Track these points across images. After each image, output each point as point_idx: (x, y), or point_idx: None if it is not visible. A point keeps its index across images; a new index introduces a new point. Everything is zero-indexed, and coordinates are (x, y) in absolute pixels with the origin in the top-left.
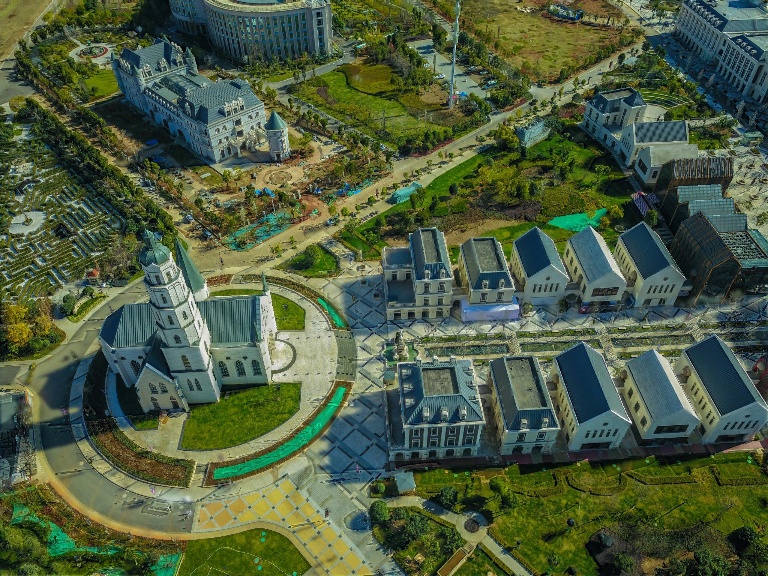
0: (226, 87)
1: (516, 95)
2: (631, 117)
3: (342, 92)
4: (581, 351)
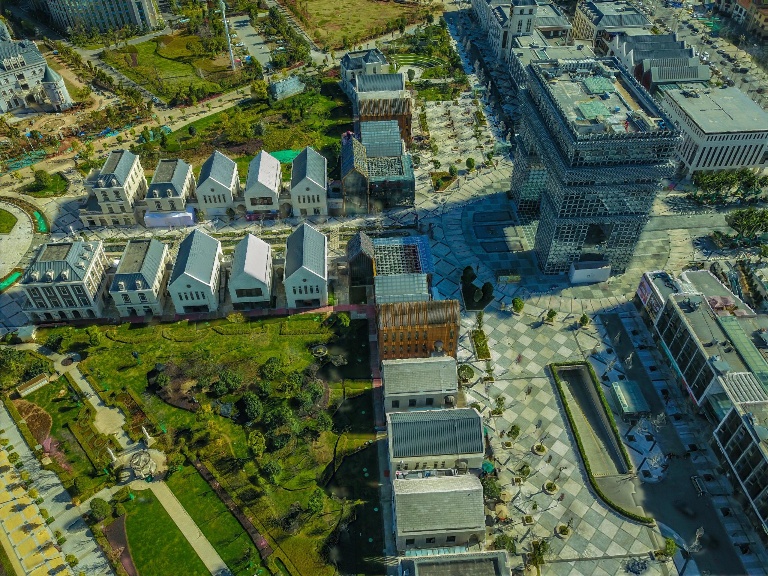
0: (13, 47)
1: (293, 58)
2: (369, 73)
3: (146, 57)
4: (192, 235)
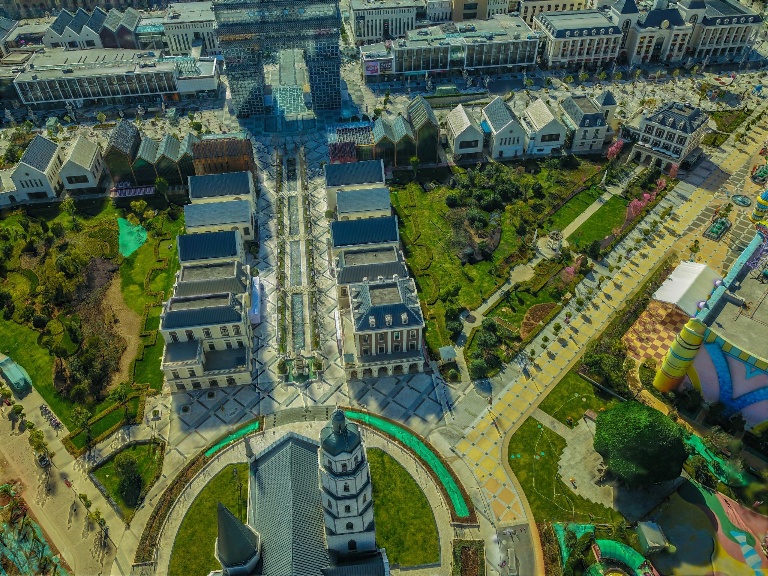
0: None
1: None
2: None
3: None
4: (338, 225)
